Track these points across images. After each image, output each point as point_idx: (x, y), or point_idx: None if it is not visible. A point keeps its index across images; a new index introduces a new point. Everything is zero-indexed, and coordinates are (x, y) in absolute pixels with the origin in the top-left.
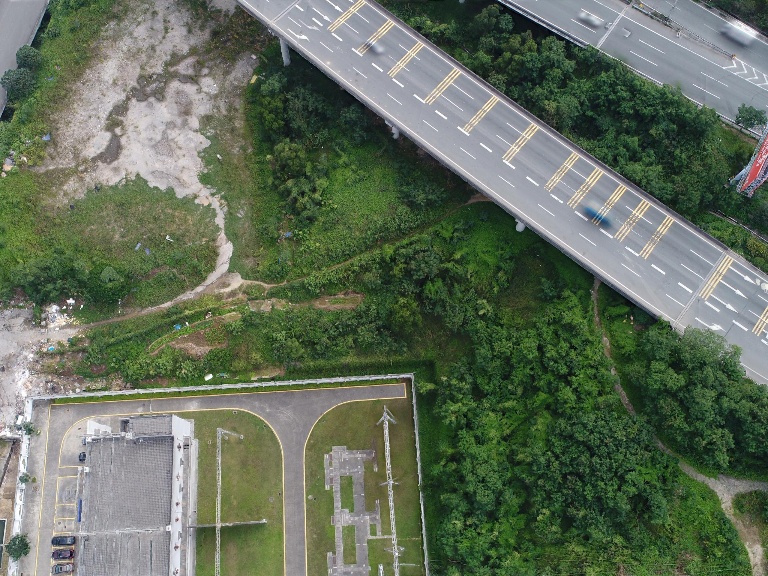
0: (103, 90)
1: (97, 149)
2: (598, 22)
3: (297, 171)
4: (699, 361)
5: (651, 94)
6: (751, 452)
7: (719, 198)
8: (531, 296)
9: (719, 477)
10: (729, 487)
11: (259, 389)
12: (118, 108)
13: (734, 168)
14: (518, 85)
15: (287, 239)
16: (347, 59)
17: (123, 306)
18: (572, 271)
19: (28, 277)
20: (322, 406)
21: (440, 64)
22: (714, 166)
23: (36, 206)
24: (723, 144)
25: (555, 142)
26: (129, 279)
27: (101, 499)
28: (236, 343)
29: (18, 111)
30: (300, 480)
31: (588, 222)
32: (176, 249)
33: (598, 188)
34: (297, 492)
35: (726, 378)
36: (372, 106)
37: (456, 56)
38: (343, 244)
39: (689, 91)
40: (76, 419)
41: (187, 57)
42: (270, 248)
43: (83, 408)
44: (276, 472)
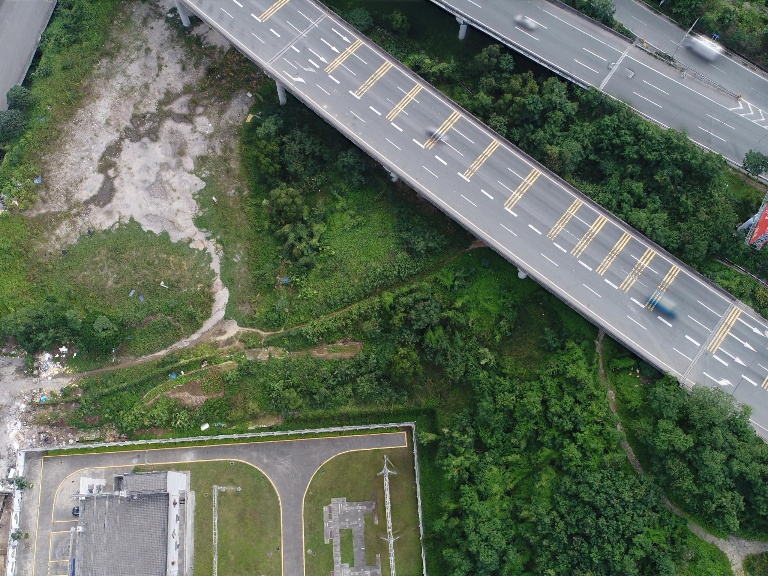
0: (96, 130)
1: (90, 192)
2: (601, 62)
3: (294, 217)
4: (708, 422)
5: (656, 139)
6: (762, 515)
7: (726, 247)
8: (534, 346)
9: (729, 538)
10: (739, 548)
11: (256, 439)
12: (111, 149)
13: (741, 215)
14: (519, 127)
15: (284, 285)
16: (344, 102)
17: (117, 354)
18: (576, 320)
19: (19, 327)
20: (321, 456)
21: (439, 107)
22: (721, 215)
23: (28, 252)
24: (730, 189)
25: (558, 188)
26: (123, 327)
27: (95, 559)
28: (233, 392)
29: (9, 153)
30: (299, 534)
31: (592, 272)
32: (171, 296)
33: (602, 236)
34: (296, 546)
35: (736, 439)
36: (370, 152)
37: (456, 95)
38: (341, 291)
39: (694, 134)
40: (69, 471)
41: (181, 95)
42: (267, 294)
43: (77, 460)
44: (274, 525)
